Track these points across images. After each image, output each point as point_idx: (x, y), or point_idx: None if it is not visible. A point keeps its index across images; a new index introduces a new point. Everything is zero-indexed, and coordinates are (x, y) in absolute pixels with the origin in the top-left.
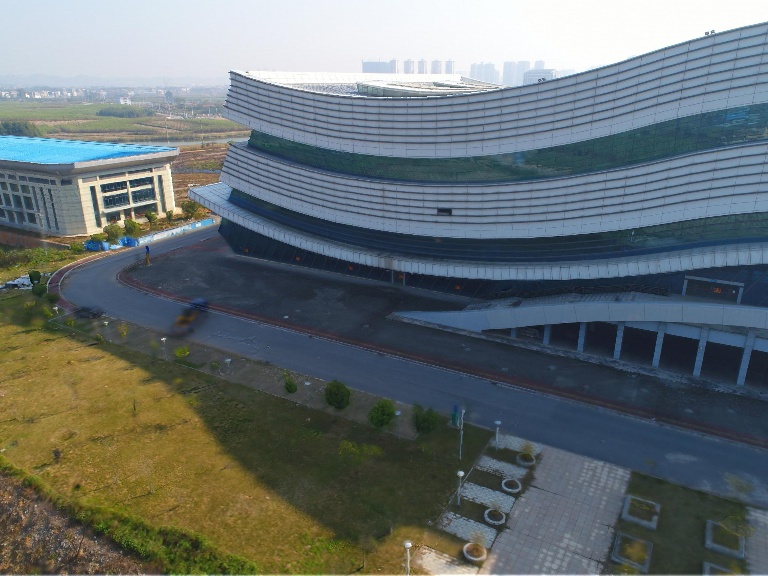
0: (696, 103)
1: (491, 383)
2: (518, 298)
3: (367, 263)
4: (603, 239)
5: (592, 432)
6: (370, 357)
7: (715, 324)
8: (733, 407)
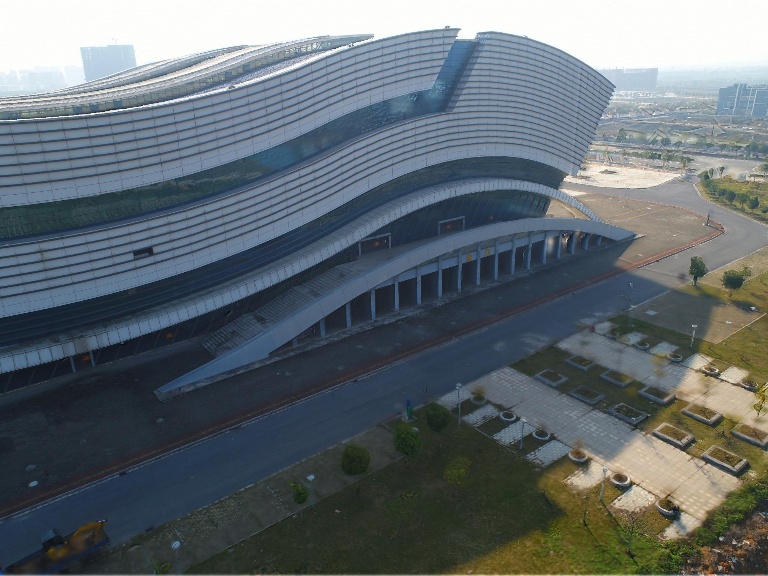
0: (353, 102)
1: (354, 382)
2: (248, 314)
3: (43, 360)
4: (301, 231)
5: (455, 364)
6: (234, 437)
7: (426, 261)
8: (460, 309)
